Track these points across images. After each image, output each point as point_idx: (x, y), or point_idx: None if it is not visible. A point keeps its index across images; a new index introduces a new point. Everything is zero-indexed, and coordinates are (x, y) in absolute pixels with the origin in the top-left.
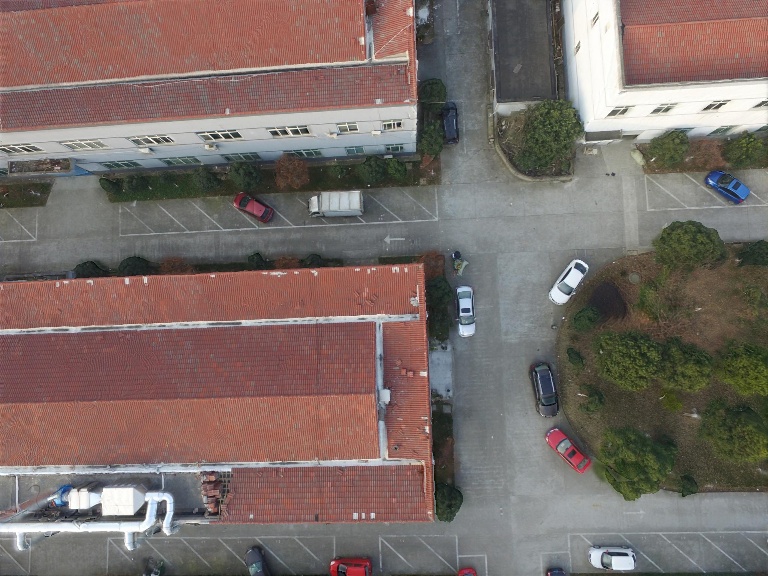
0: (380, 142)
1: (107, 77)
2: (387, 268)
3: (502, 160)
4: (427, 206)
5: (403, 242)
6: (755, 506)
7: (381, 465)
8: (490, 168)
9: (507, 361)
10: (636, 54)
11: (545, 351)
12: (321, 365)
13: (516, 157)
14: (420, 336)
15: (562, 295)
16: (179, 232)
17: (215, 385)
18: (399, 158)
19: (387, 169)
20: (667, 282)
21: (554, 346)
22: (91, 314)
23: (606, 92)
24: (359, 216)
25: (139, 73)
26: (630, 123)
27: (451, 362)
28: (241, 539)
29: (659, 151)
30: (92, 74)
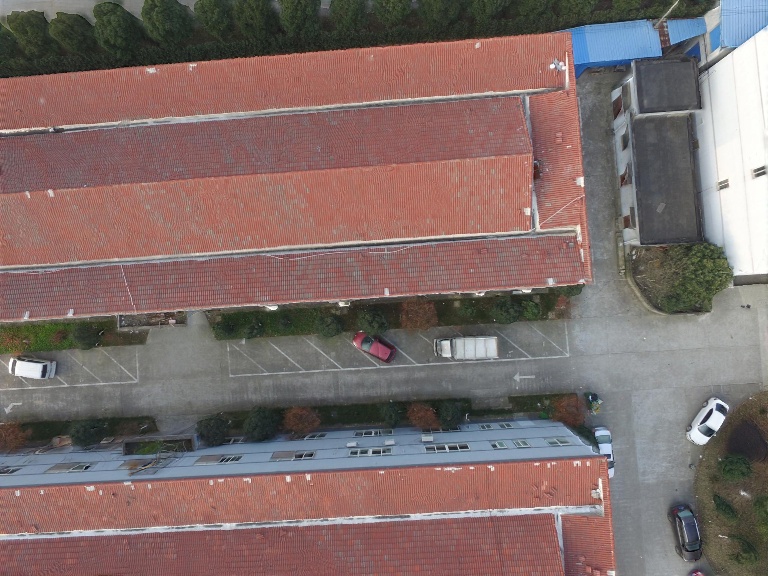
0: None
1: (245, 247)
2: (568, 462)
3: (634, 292)
4: (557, 342)
5: (533, 380)
6: None
7: None
8: (621, 300)
9: (645, 502)
10: None
11: (683, 491)
12: (505, 568)
13: (654, 295)
14: (606, 533)
15: (703, 437)
16: (294, 372)
17: None
18: None
19: (523, 312)
20: None
21: (692, 486)
22: (248, 511)
23: None
24: None
25: (281, 243)
26: None
27: None
28: None
29: None
30: (229, 245)
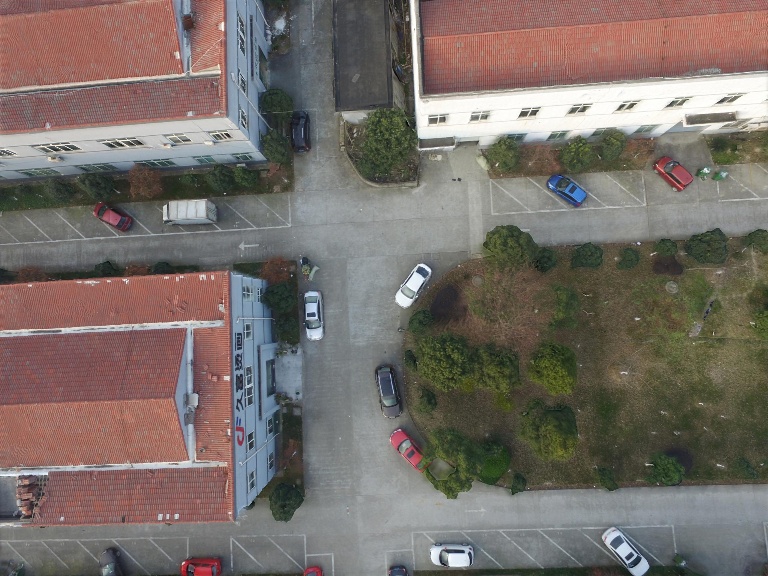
0: (223, 151)
1: None
2: (194, 276)
3: (352, 167)
4: (280, 213)
5: (257, 248)
6: (592, 503)
7: (190, 467)
8: (341, 175)
9: (355, 364)
10: (438, 64)
11: (392, 353)
12: (128, 371)
13: None
14: (224, 341)
15: (405, 298)
16: (43, 241)
17: (26, 391)
18: (254, 166)
19: (234, 178)
20: (508, 284)
21: (400, 348)
22: None
23: None
24: (214, 224)
25: None
26: (458, 130)
27: (301, 365)
28: (98, 541)
29: None
30: None
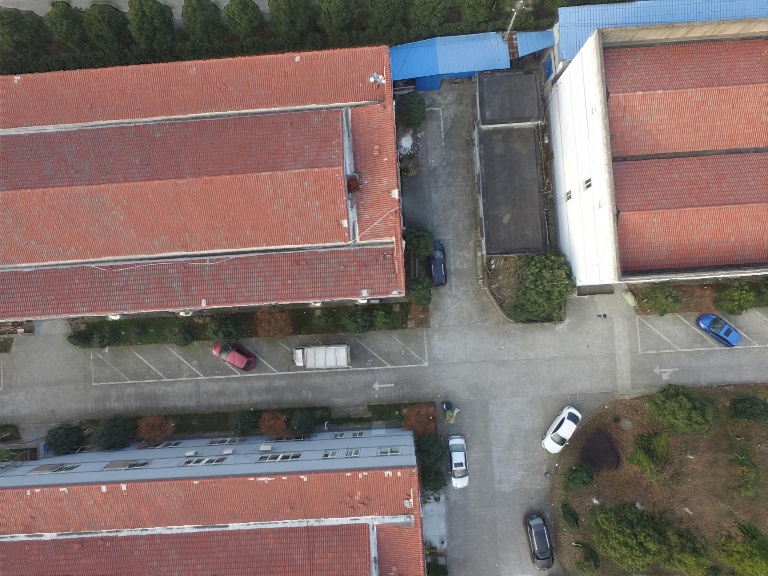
0: None
1: (70, 258)
2: (379, 472)
3: (492, 302)
4: (416, 350)
5: (392, 388)
6: None
7: None
8: (480, 310)
9: (501, 510)
10: (631, 238)
11: (539, 499)
12: None
13: (507, 304)
14: (415, 543)
15: (555, 445)
16: (156, 380)
17: None
18: (386, 300)
19: (374, 321)
20: (659, 428)
21: (548, 494)
22: (67, 520)
23: (600, 269)
24: None
25: (105, 254)
26: None
27: (445, 513)
28: None
29: (651, 292)
30: (53, 255)
